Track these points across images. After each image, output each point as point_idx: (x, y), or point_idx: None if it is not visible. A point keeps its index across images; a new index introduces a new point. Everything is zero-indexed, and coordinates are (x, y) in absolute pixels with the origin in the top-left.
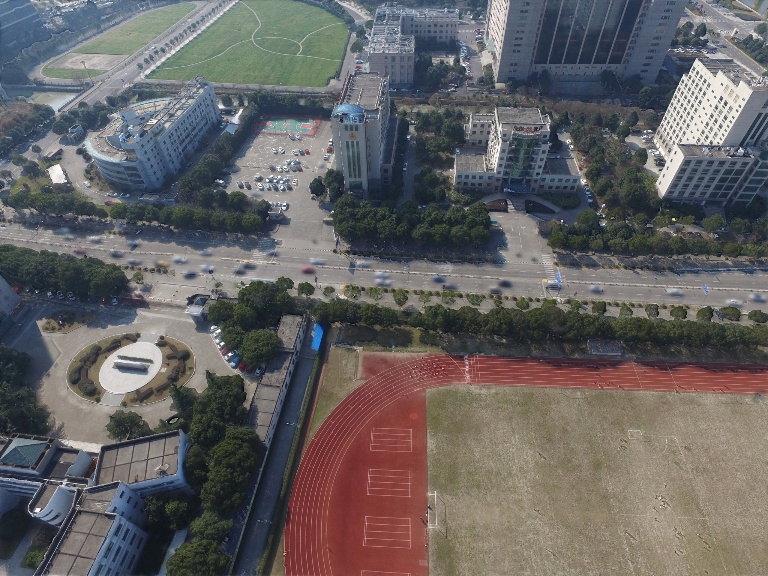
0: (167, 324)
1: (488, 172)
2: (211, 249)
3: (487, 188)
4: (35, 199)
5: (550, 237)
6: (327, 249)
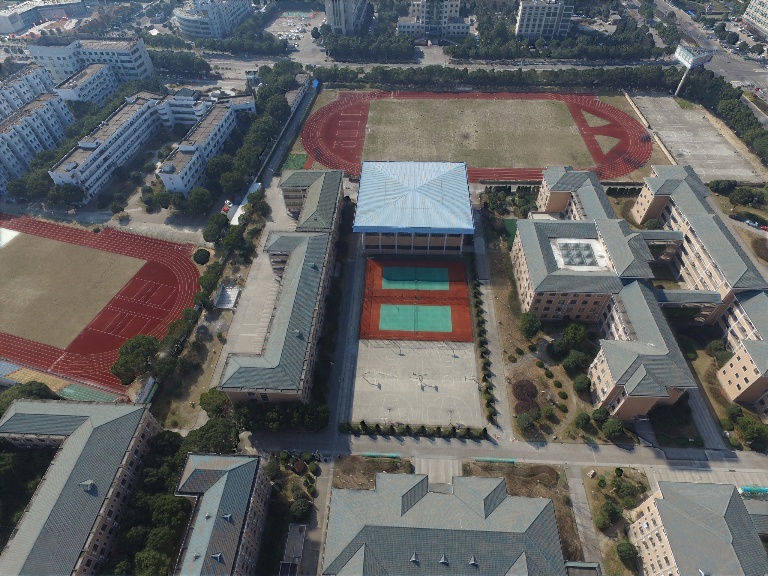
0: (235, 85)
1: (416, 23)
2: (255, 61)
3: (417, 34)
4: (150, 37)
5: (446, 49)
6: (321, 60)
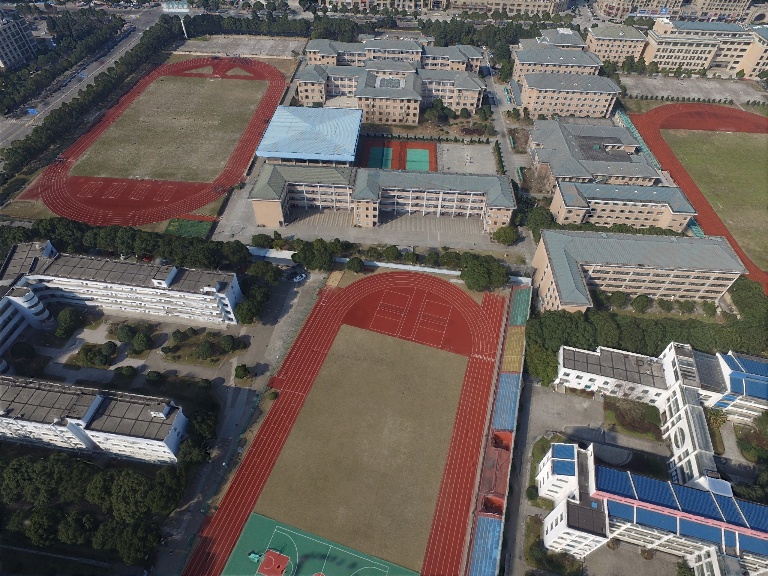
0: None
1: None
2: None
3: None
4: None
5: None
6: None
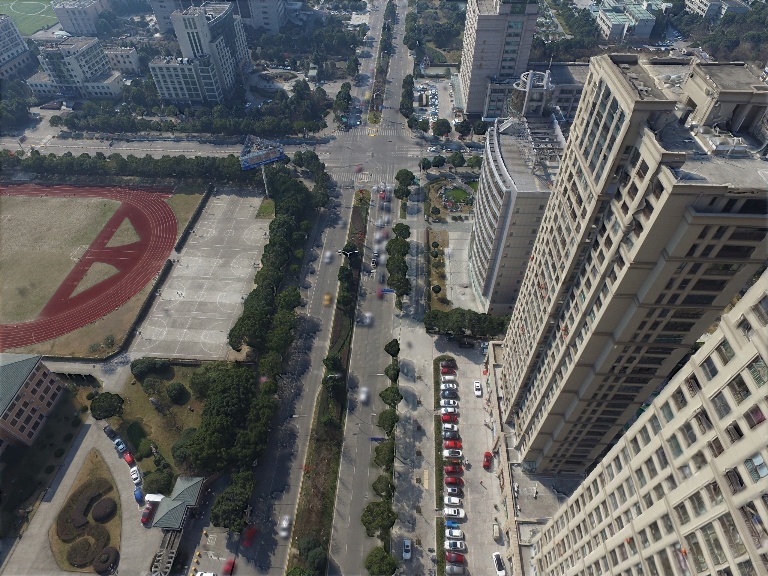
0: None
1: (47, 81)
2: None
3: (53, 94)
4: None
5: None
6: None
